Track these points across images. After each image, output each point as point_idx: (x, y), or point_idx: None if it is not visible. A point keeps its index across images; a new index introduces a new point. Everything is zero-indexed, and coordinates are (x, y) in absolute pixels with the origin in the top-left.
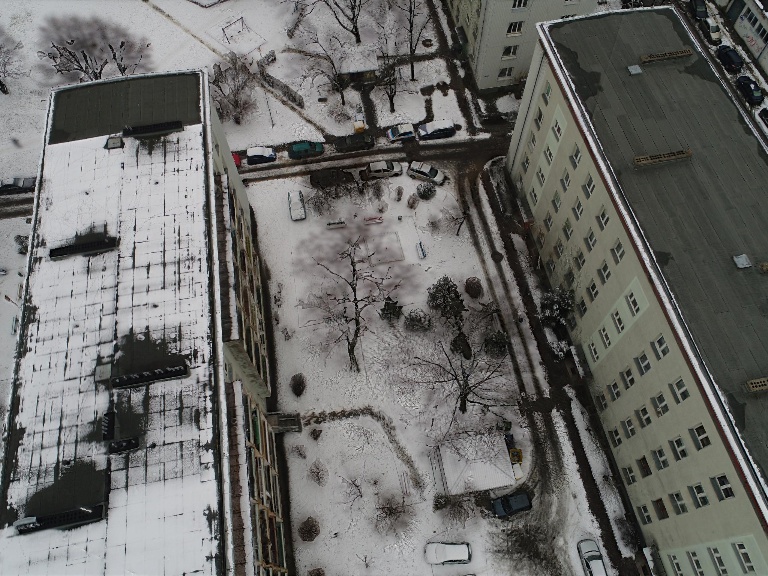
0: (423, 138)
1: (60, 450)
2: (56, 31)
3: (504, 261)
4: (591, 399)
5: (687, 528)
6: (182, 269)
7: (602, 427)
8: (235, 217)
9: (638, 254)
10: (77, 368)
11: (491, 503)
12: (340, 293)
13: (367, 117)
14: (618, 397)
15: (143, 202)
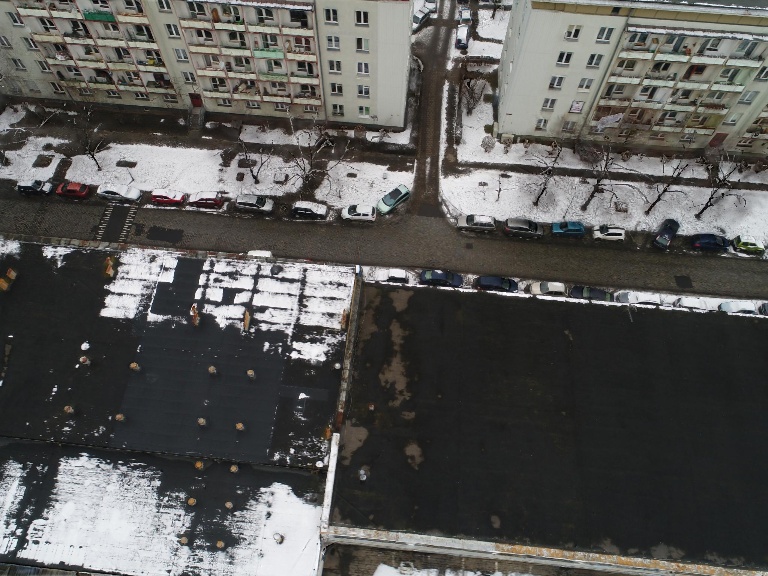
0: None
1: None
2: None
3: None
4: None
5: None
6: None
7: None
8: None
9: None
10: None
11: None
12: None
13: (491, 5)
14: None
15: None
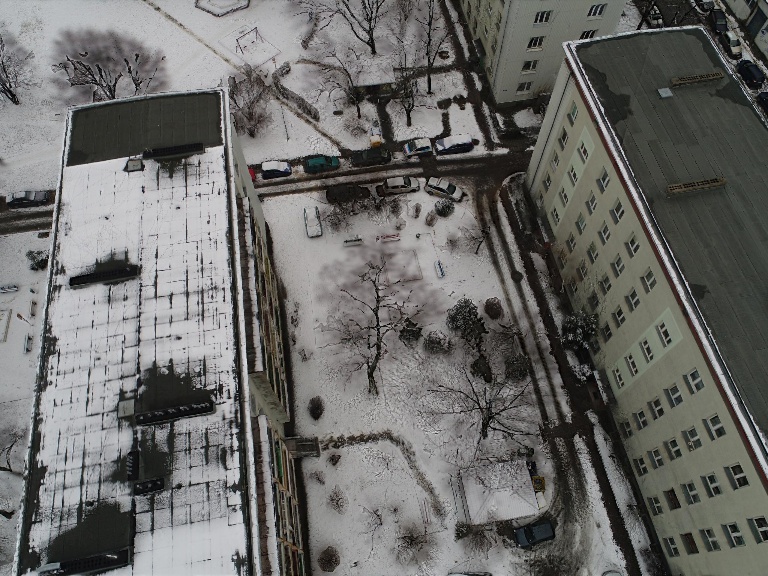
0: (440, 153)
1: (83, 490)
2: (67, 40)
3: (524, 281)
4: (614, 425)
5: (719, 566)
6: (206, 299)
7: (626, 454)
8: (256, 240)
9: (671, 285)
10: (99, 403)
11: (514, 532)
12: (358, 313)
13: (383, 131)
14: (645, 426)
15: (164, 228)
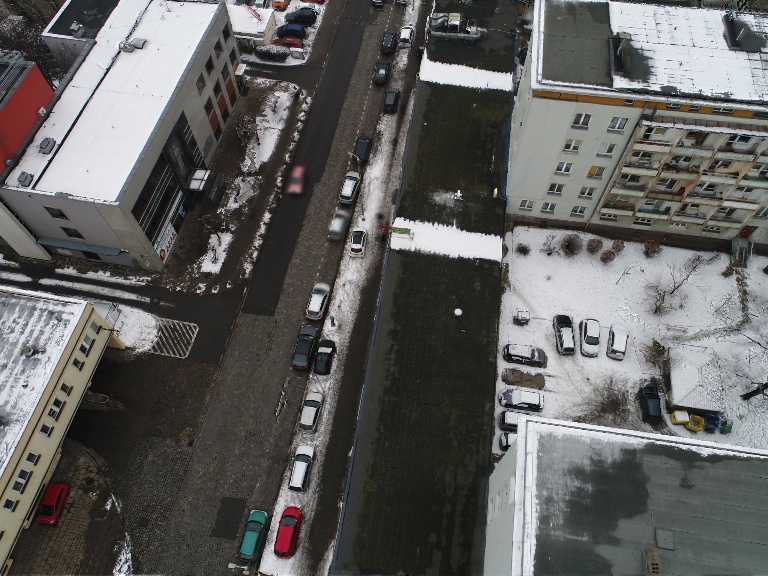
0: None
1: None
2: None
3: None
4: None
5: None
6: None
7: None
8: None
9: None
10: None
11: None
12: None
13: None
14: None
15: None
